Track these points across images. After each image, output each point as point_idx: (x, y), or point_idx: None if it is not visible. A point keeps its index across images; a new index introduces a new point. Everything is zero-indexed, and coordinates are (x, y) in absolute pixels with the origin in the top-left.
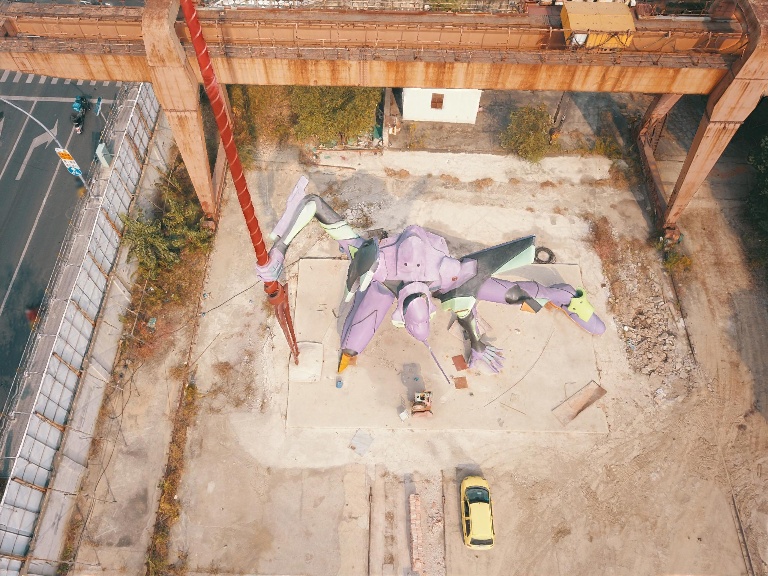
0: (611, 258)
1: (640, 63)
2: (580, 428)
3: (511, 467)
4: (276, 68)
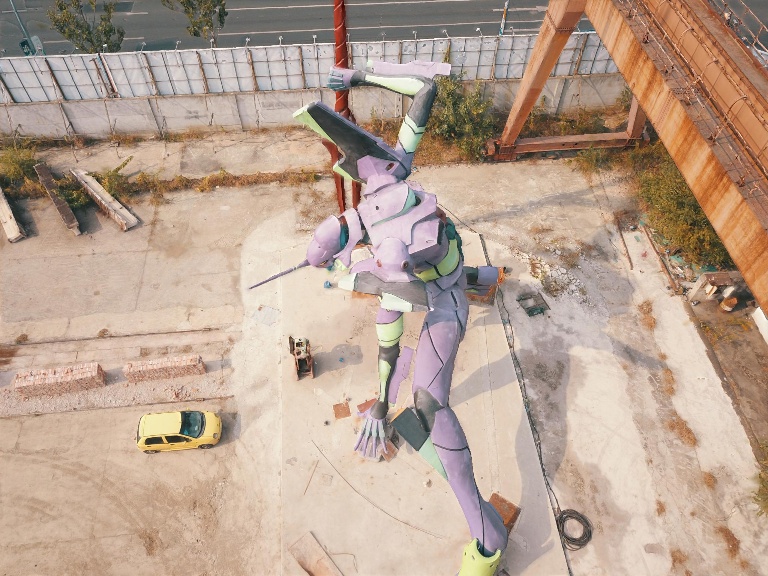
0: None
1: None
2: (287, 575)
3: (236, 477)
4: (624, 40)
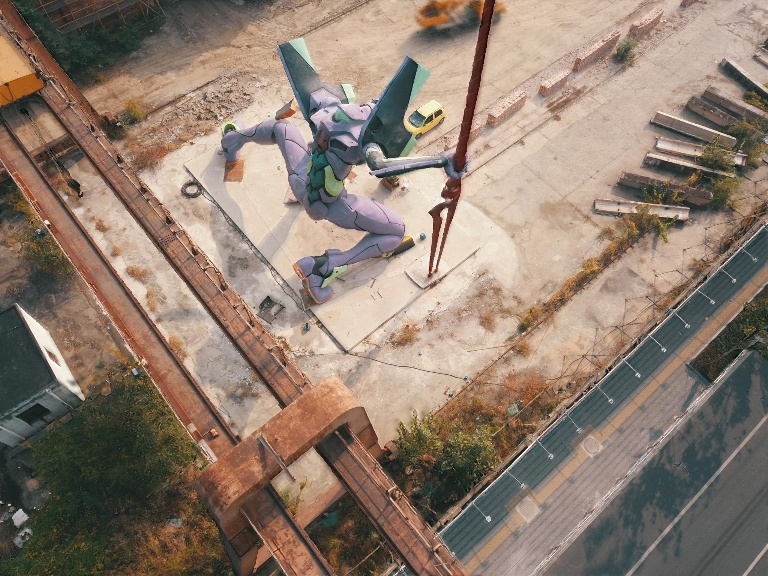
0: (158, 153)
1: (26, 46)
2: None
3: None
4: None
